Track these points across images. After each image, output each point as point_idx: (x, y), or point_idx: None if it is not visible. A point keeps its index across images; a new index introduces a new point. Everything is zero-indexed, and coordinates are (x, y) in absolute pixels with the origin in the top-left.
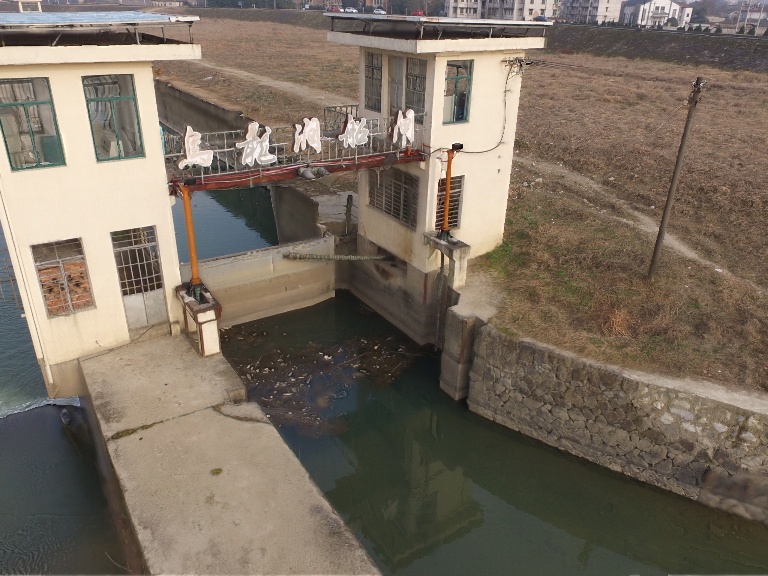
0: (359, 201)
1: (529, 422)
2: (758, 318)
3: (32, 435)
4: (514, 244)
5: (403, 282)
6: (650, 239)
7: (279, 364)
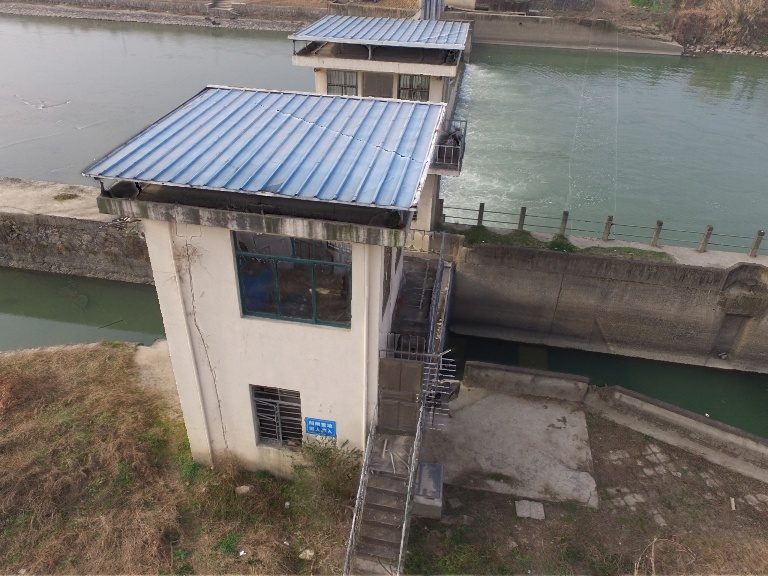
0: None
1: None
2: None
3: None
4: (185, 491)
5: None
6: None
7: None
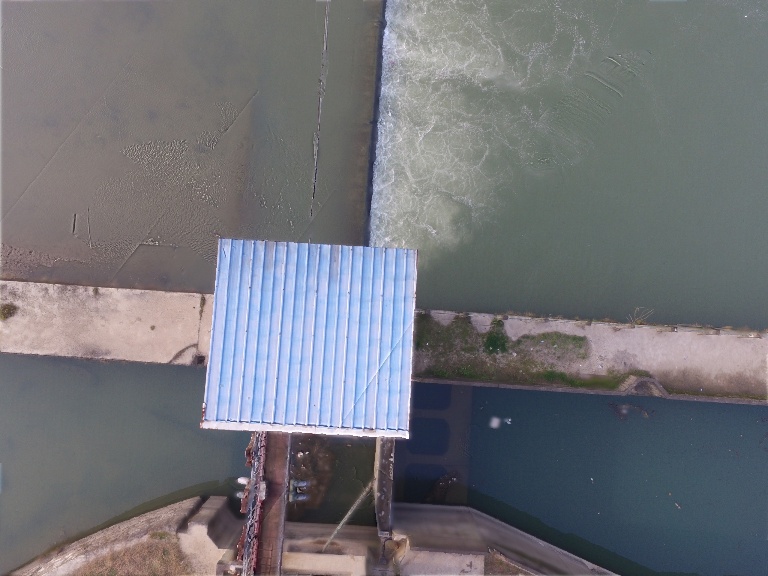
0: (363, 573)
1: None
2: None
3: None
4: None
5: (294, 542)
6: None
7: None
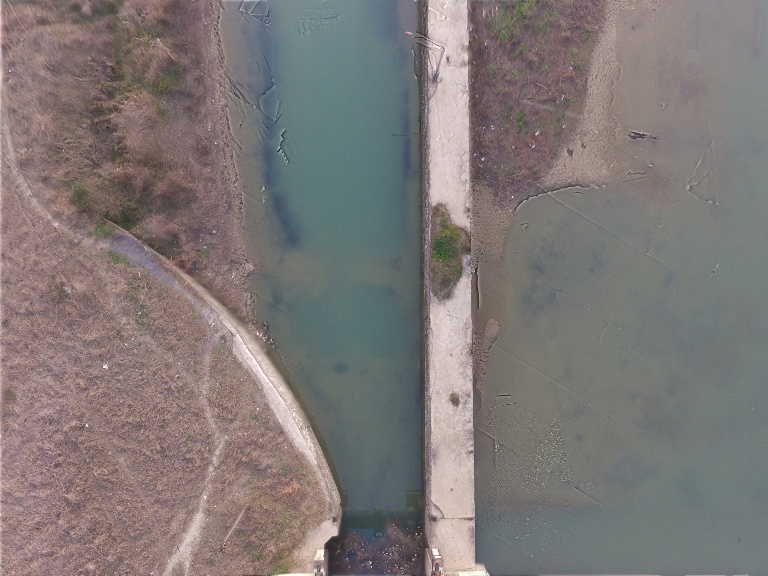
0: None
1: (332, 479)
2: (240, 460)
3: None
4: None
5: None
6: (201, 540)
7: (391, 568)
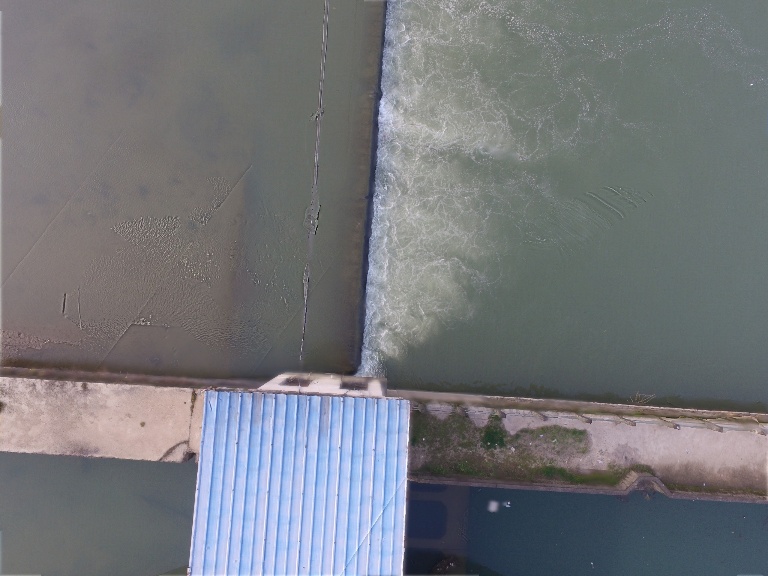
0: None
1: None
2: None
3: (334, 356)
4: None
5: None
6: None
7: None
